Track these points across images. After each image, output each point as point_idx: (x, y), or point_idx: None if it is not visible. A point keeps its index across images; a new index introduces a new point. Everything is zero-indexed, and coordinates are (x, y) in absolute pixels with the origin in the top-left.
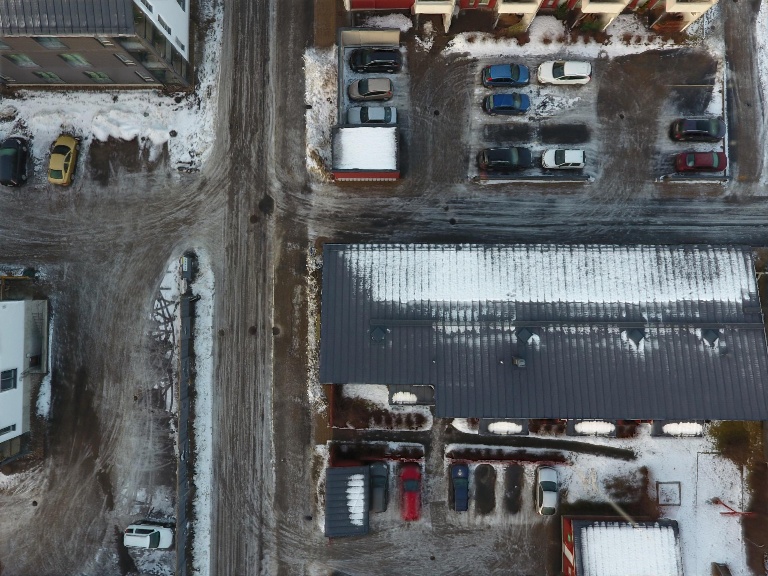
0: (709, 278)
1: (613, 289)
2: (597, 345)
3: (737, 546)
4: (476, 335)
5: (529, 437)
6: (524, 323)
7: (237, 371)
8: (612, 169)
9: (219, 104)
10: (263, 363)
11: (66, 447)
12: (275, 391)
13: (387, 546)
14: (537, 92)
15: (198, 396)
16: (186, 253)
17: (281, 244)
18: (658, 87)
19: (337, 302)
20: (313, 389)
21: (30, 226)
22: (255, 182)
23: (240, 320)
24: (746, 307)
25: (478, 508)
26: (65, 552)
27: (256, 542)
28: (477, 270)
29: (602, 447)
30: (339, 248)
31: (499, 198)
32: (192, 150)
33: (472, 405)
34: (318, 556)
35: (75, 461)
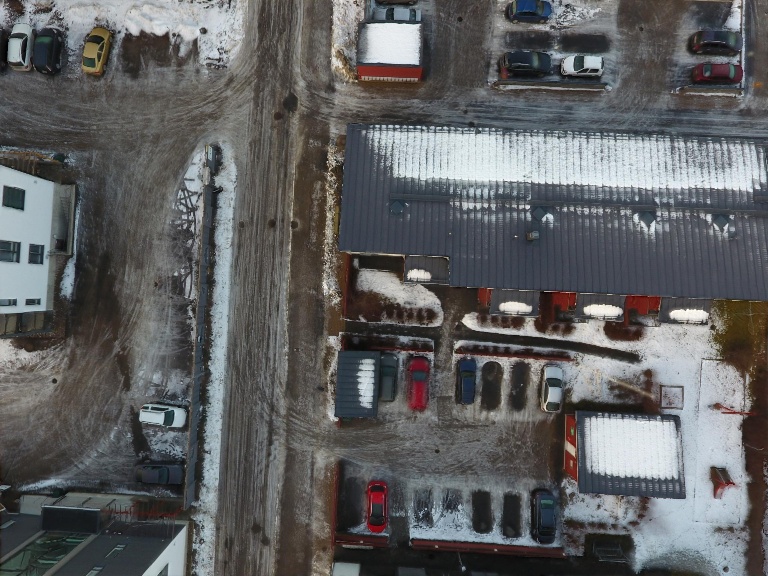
0: (721, 168)
1: (627, 175)
2: (609, 226)
3: (737, 452)
4: (492, 212)
5: (537, 337)
6: (539, 202)
7: (255, 262)
8: (629, 79)
9: (249, 4)
10: (281, 255)
11: (87, 328)
12: (291, 283)
13: (394, 437)
14: (559, 2)
15: (216, 284)
16: (211, 146)
17: (303, 141)
18: (678, 1)
19: (358, 177)
20: (328, 282)
21: (62, 113)
22: (280, 80)
23: (260, 213)
24: (757, 196)
25: (484, 404)
26: (82, 429)
27: (266, 428)
28: (495, 152)
29: (608, 349)
30: (362, 127)
31: (517, 103)
32: (221, 47)
33: (485, 276)
34: (326, 444)
35: (95, 342)
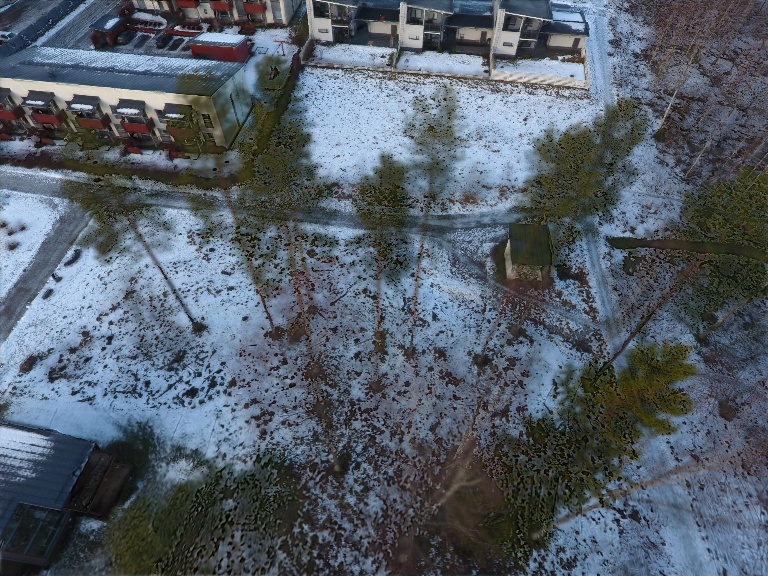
0: None
1: None
2: None
3: (287, 67)
4: None
5: None
6: None
7: None
8: None
9: None
10: None
11: None
12: None
13: None
14: None
15: None
16: None
17: None
18: None
19: None
20: None
21: None
22: None
23: None
24: None
25: (169, 49)
26: None
27: None
28: None
29: None
30: None
31: None
32: None
33: None
34: None
35: None
